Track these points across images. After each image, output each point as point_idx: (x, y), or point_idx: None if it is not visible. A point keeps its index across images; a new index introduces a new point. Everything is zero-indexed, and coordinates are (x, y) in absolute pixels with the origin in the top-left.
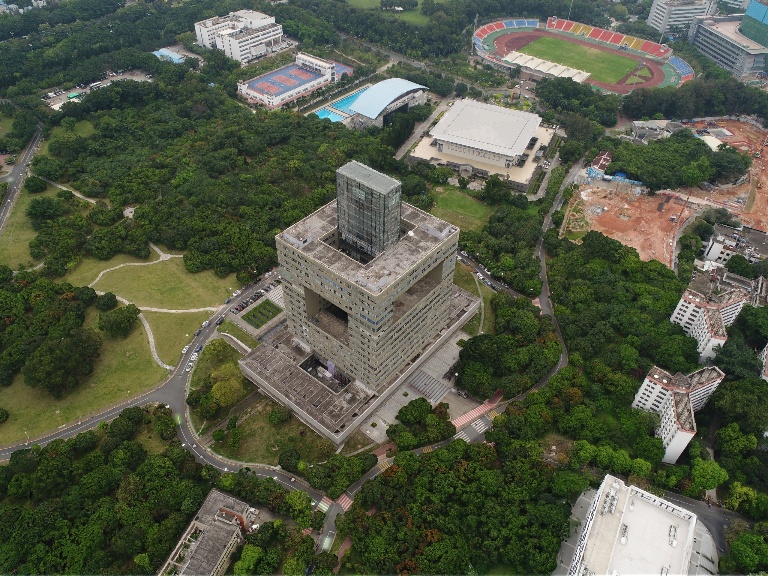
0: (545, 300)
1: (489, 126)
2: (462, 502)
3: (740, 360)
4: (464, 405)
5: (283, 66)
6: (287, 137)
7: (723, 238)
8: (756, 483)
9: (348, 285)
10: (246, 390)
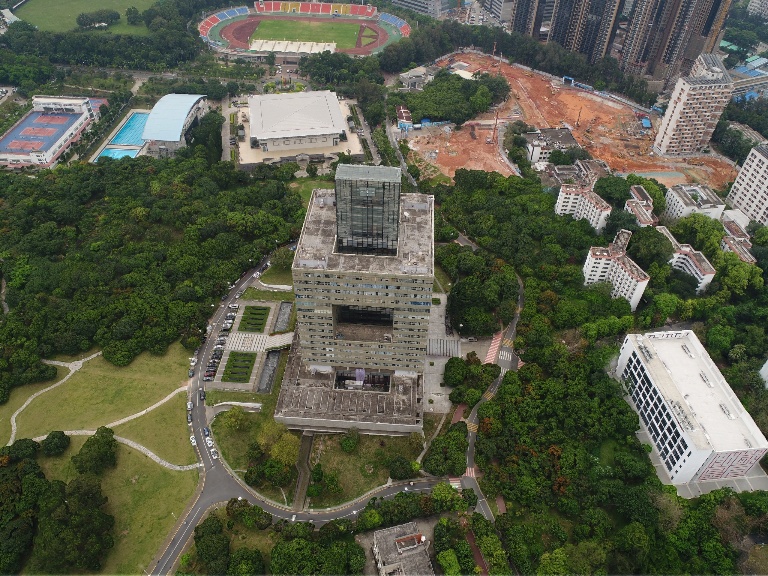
0: (462, 239)
1: (299, 113)
2: (548, 415)
3: (626, 219)
4: (481, 347)
5: (22, 117)
6: (97, 190)
7: (538, 142)
8: (687, 295)
9: (397, 279)
10: None
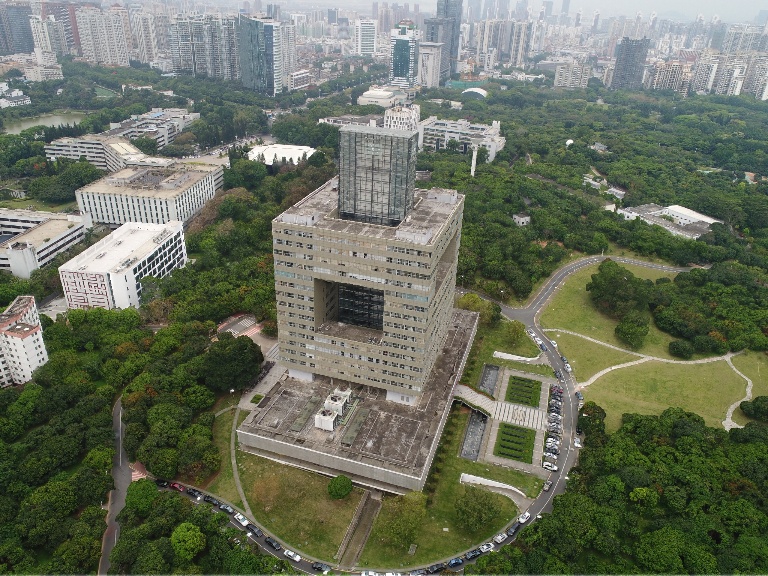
0: (120, 503)
1: None
2: None
3: None
4: None
5: None
6: None
7: None
8: None
9: None
10: None
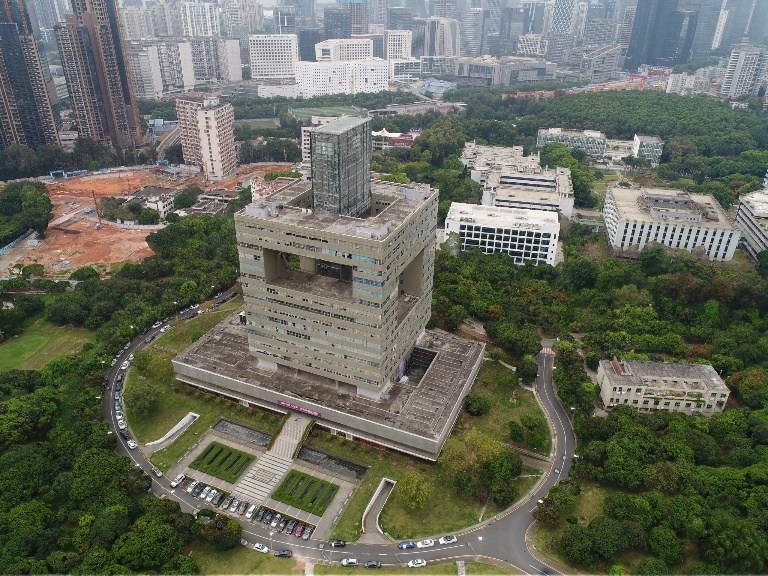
0: None
1: None
2: None
3: None
4: None
5: None
6: None
7: None
8: None
9: None
10: None
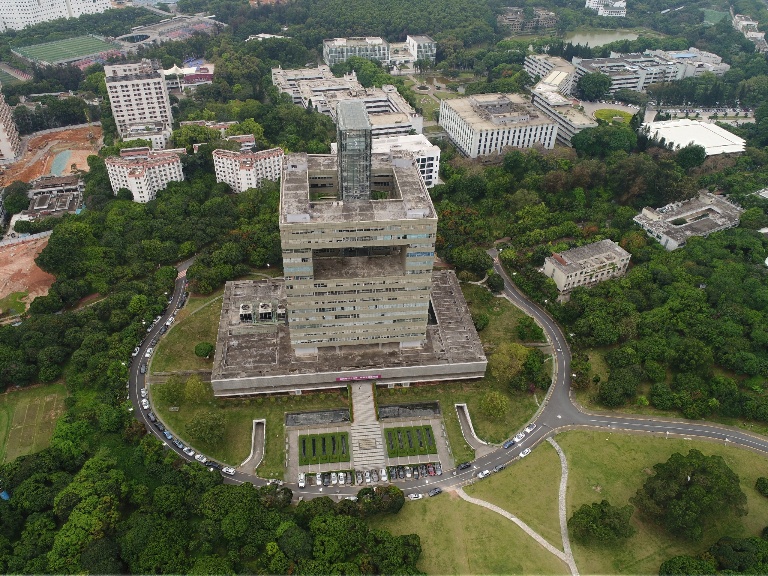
0: None
1: None
2: None
3: None
4: None
5: None
6: None
7: None
8: None
9: None
10: (488, 369)
